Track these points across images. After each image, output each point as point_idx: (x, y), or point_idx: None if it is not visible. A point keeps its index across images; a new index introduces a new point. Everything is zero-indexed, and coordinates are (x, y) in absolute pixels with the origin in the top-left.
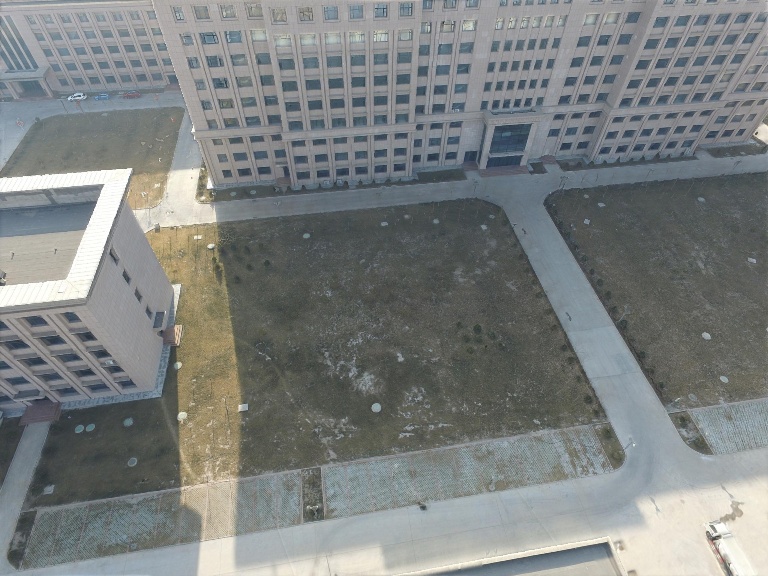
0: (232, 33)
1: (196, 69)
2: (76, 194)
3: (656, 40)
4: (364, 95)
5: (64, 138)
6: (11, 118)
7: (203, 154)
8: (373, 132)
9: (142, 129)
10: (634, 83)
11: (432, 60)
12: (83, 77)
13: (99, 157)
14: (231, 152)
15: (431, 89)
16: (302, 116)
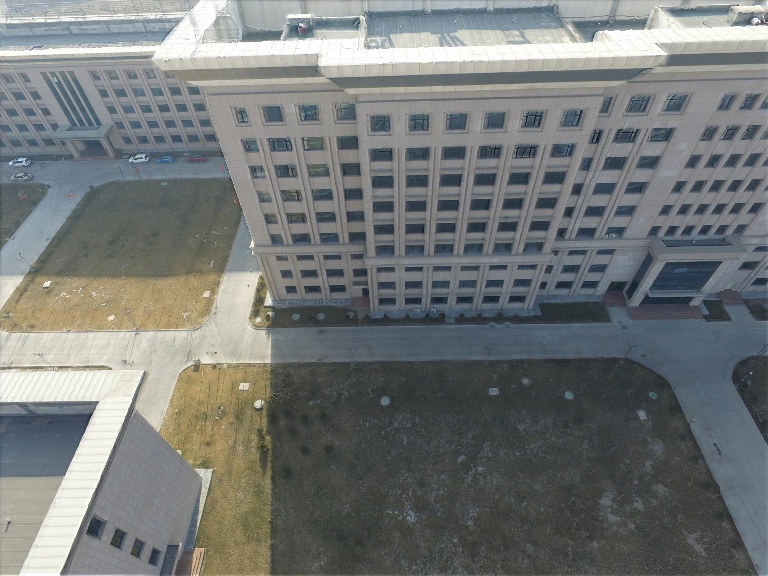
0: (311, 139)
1: (260, 179)
2: (61, 407)
3: None
4: (485, 220)
5: (115, 214)
6: (66, 182)
7: (263, 269)
8: (489, 261)
9: (202, 206)
10: None
11: (591, 176)
12: (148, 135)
13: (148, 244)
14: (298, 268)
15: (581, 210)
16: (395, 240)
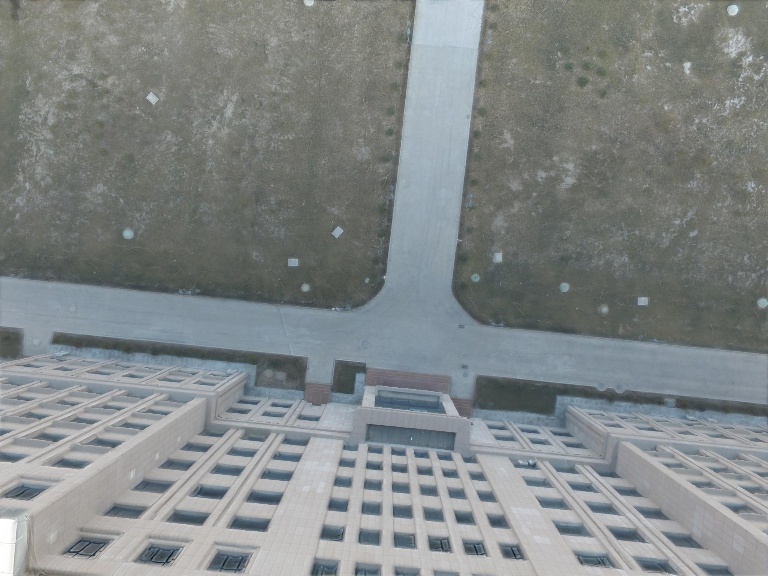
0: None
1: None
2: None
3: None
4: None
5: None
6: None
7: None
8: None
9: None
10: None
11: (643, 524)
12: None
13: None
14: None
15: (605, 490)
16: None
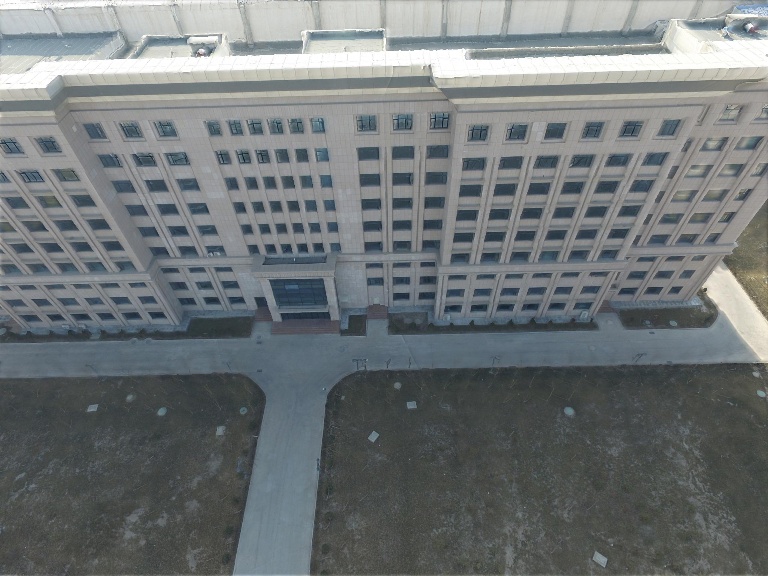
0: None
1: None
2: None
3: (477, 186)
4: (52, 241)
5: None
6: None
7: None
8: (93, 280)
9: None
10: (464, 236)
11: (144, 198)
12: None
13: None
14: None
15: (163, 230)
16: None
